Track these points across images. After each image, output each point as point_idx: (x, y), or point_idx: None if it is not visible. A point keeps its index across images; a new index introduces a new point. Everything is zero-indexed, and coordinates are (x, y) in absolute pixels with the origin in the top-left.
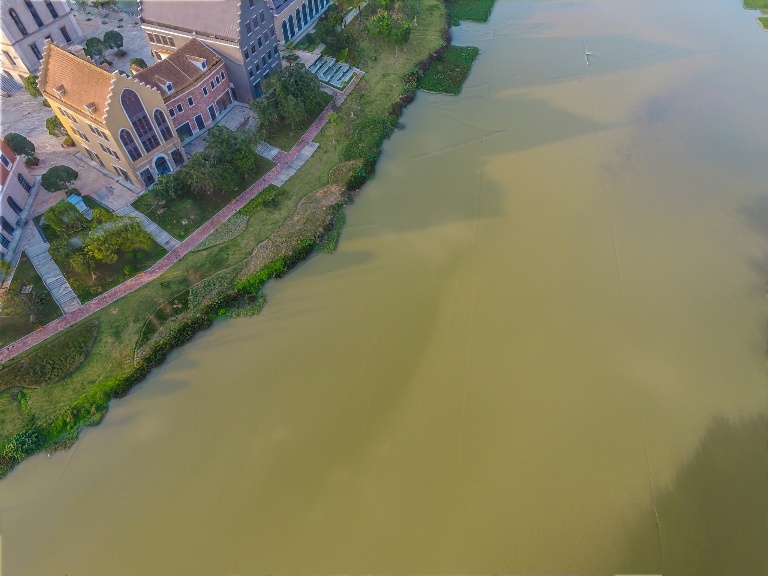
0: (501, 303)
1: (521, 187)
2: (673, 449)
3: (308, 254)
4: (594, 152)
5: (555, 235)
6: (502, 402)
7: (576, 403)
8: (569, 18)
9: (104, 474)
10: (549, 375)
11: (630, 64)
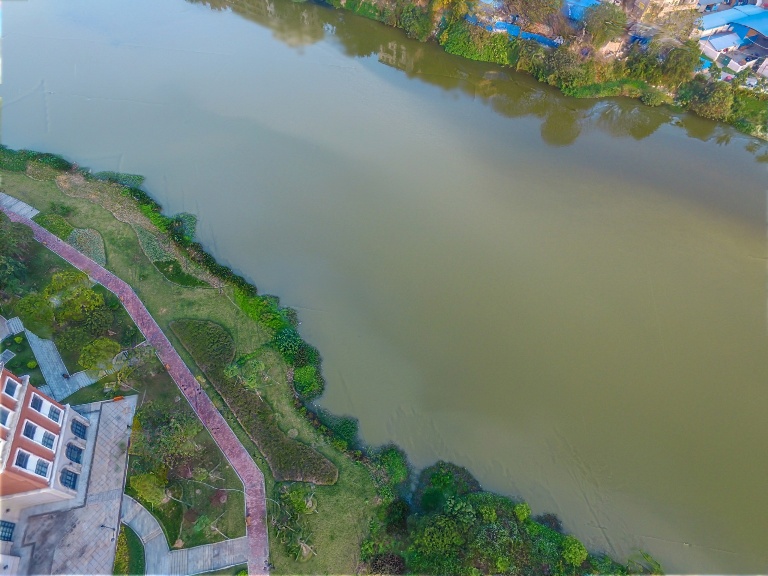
0: (225, 98)
1: (117, 82)
2: (327, 58)
3: None
4: (99, 45)
5: (175, 71)
6: (293, 106)
7: (299, 80)
8: None
9: (318, 282)
10: (280, 87)
11: None
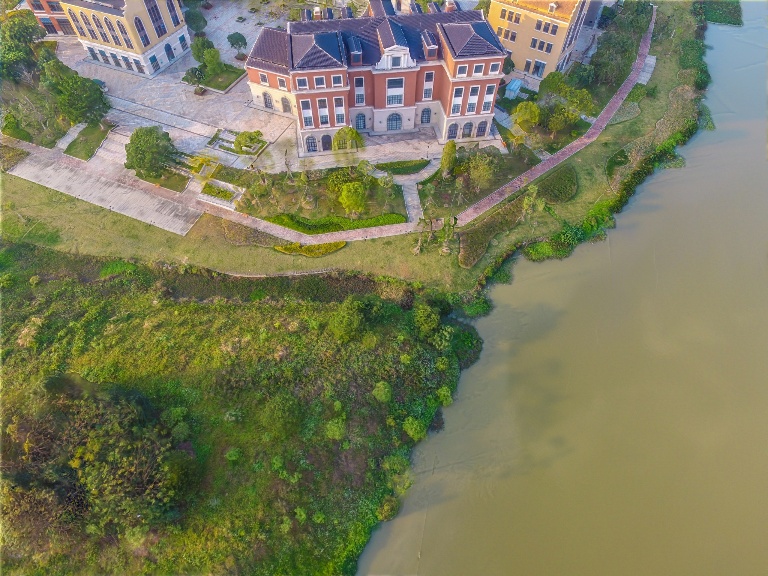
0: None
1: None
2: None
3: (697, 130)
4: None
5: None
6: None
7: None
8: None
9: (643, 255)
10: None
11: None
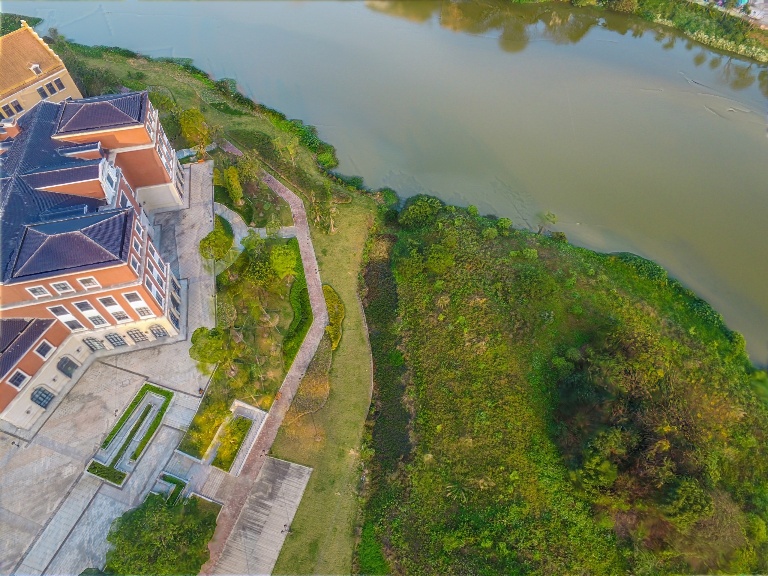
0: (247, 11)
1: None
2: None
3: None
4: None
5: None
6: (301, 15)
7: None
8: None
9: (330, 111)
10: (289, 3)
11: None
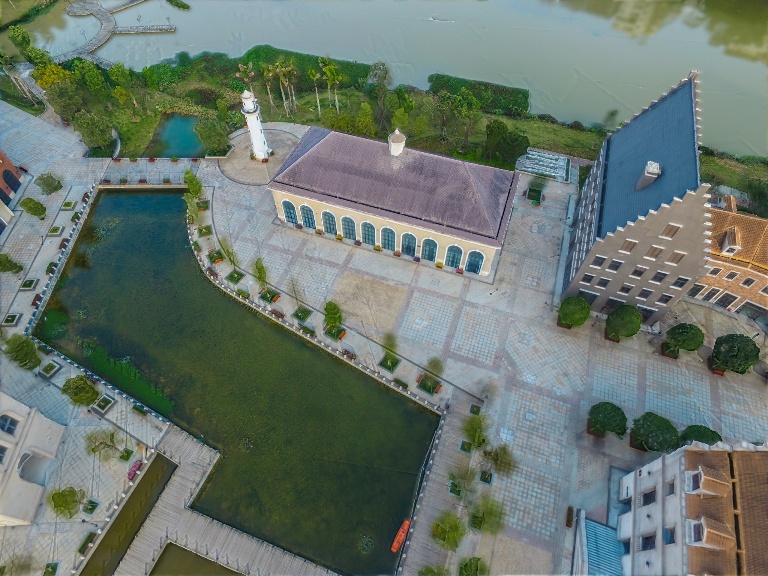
0: None
1: (643, 70)
2: None
3: None
4: (584, 35)
5: (691, 60)
6: None
7: None
8: (360, 20)
9: None
10: None
11: (448, 3)
